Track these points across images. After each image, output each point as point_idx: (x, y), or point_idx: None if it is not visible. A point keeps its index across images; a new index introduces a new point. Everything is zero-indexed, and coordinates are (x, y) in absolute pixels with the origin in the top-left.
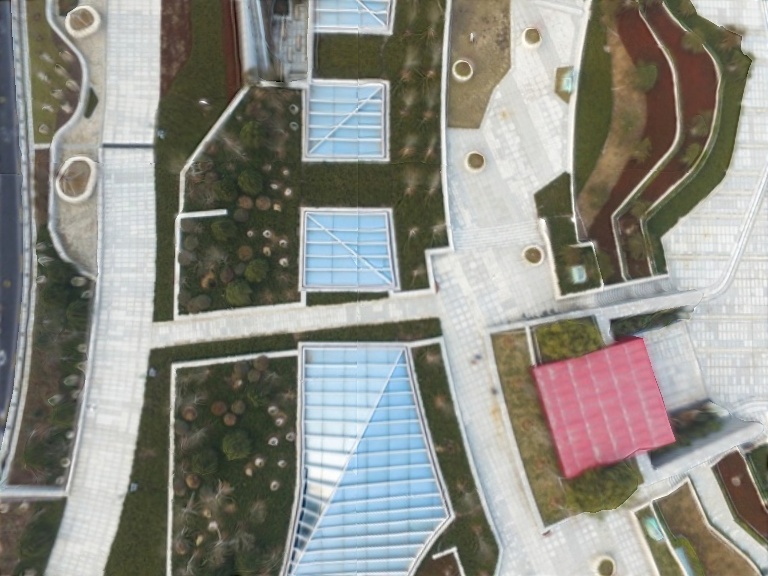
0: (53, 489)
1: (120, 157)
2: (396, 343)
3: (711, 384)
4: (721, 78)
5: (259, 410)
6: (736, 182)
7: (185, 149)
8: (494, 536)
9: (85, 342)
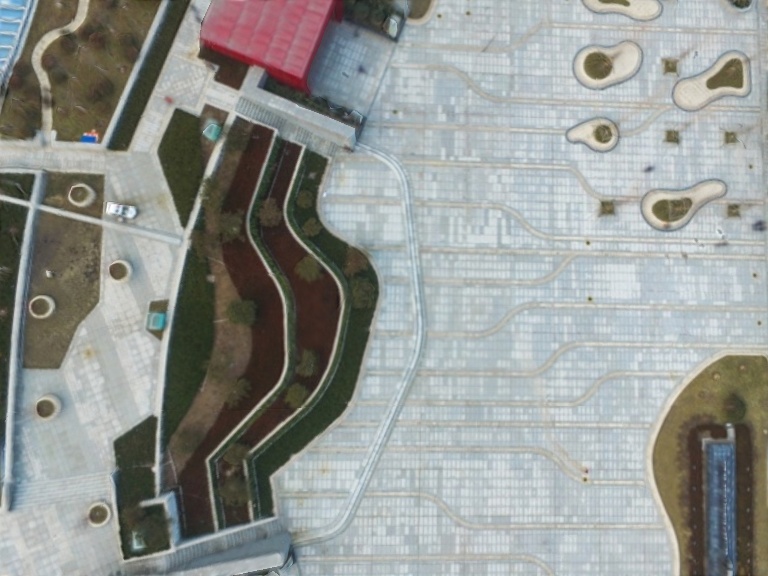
0: None
1: None
2: None
3: None
4: (345, 304)
5: None
6: (362, 412)
7: None
8: None
9: None
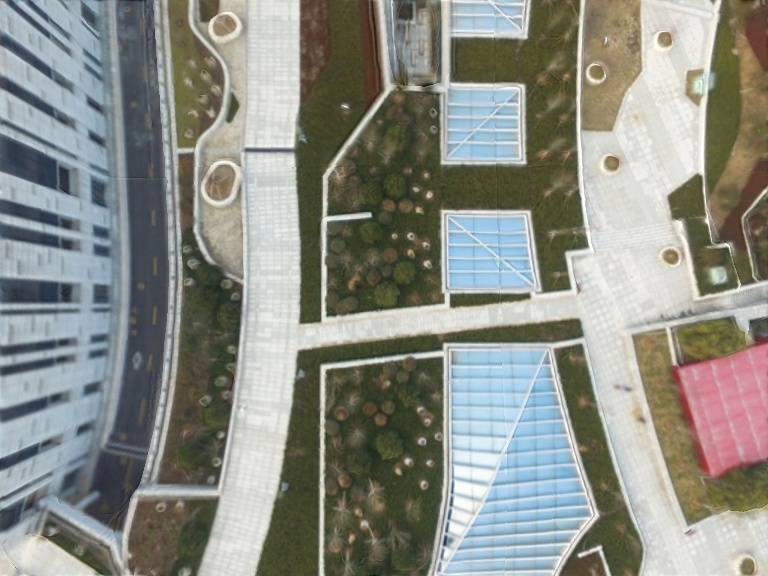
0: (205, 488)
1: (262, 161)
2: (539, 344)
3: None
4: None
5: (409, 410)
6: None
7: (326, 153)
8: (638, 535)
9: (234, 344)
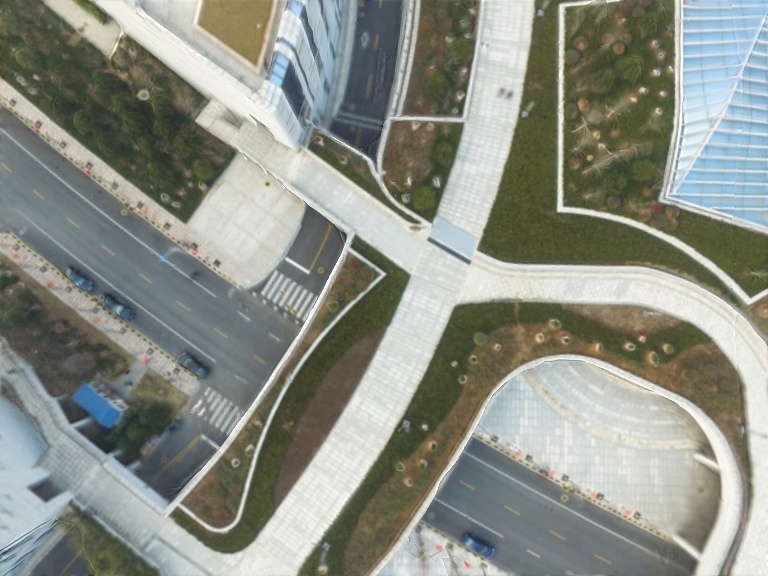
0: (451, 116)
1: None
2: None
3: None
4: None
5: (645, 42)
6: None
7: None
8: None
9: None
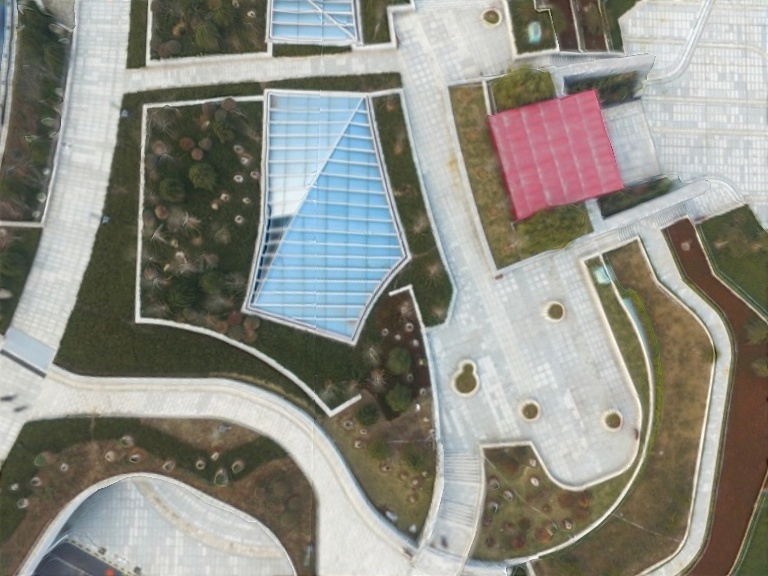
0: (29, 220)
1: None
2: (358, 93)
3: (665, 162)
4: None
5: (225, 147)
6: None
7: None
8: (448, 275)
9: (62, 86)
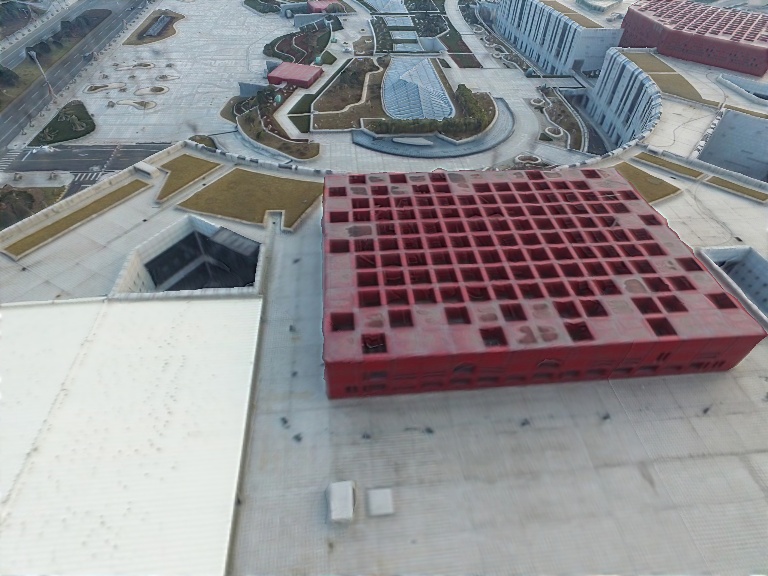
0: None
1: (469, 33)
2: None
3: None
4: None
5: None
6: None
7: None
8: None
9: None
